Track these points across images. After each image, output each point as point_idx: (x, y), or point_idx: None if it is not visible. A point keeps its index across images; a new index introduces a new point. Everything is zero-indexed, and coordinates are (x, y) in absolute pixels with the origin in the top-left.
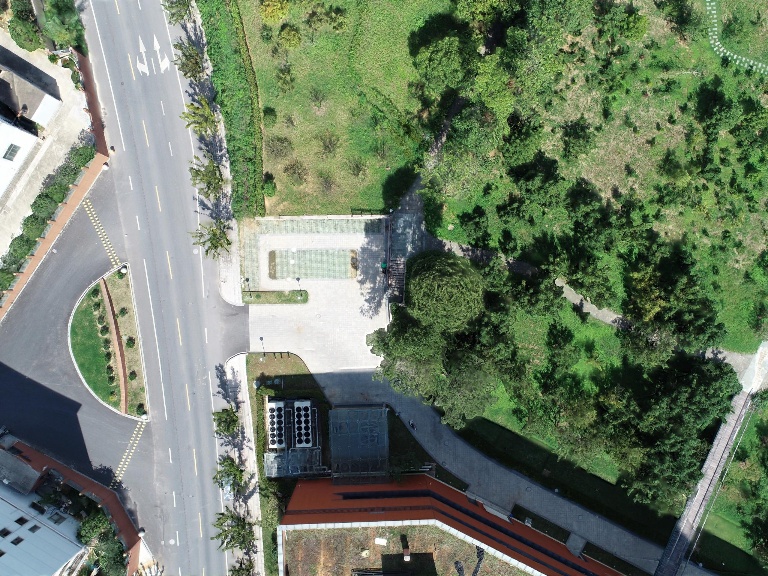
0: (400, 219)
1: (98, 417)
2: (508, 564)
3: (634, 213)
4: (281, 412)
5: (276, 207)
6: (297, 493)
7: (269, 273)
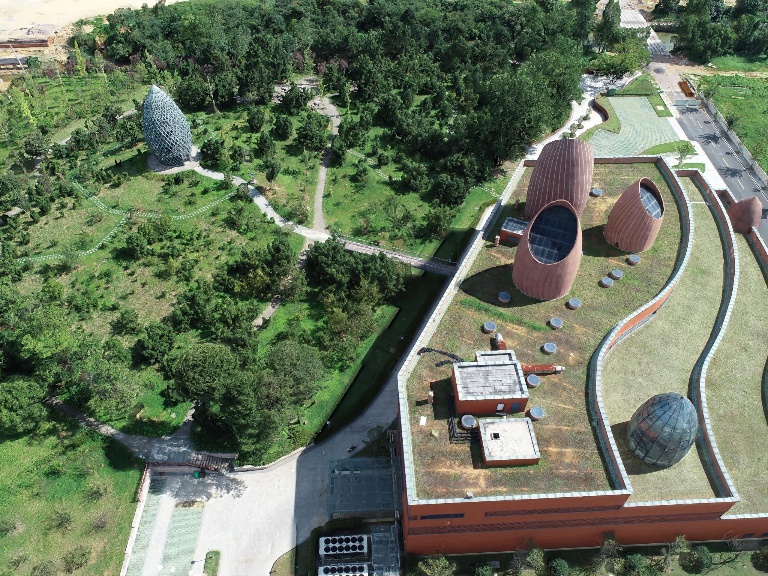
0: (155, 457)
1: None
2: (435, 333)
3: None
4: (329, 569)
5: None
6: (406, 535)
7: None
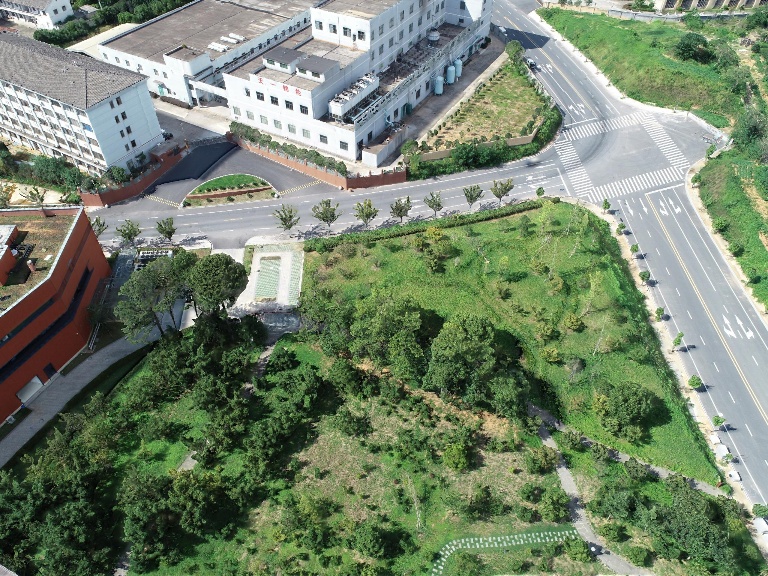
0: (295, 319)
1: (187, 187)
2: None
3: (282, 482)
4: None
5: (310, 257)
6: (102, 253)
7: (265, 257)
